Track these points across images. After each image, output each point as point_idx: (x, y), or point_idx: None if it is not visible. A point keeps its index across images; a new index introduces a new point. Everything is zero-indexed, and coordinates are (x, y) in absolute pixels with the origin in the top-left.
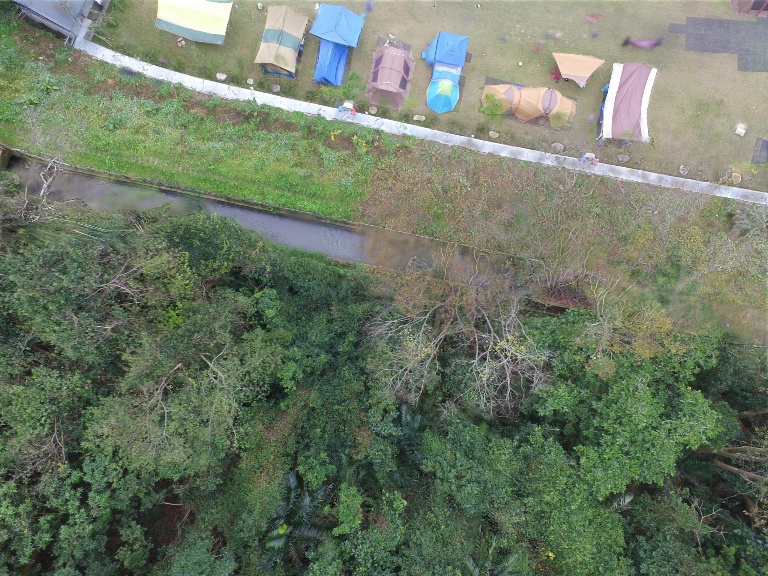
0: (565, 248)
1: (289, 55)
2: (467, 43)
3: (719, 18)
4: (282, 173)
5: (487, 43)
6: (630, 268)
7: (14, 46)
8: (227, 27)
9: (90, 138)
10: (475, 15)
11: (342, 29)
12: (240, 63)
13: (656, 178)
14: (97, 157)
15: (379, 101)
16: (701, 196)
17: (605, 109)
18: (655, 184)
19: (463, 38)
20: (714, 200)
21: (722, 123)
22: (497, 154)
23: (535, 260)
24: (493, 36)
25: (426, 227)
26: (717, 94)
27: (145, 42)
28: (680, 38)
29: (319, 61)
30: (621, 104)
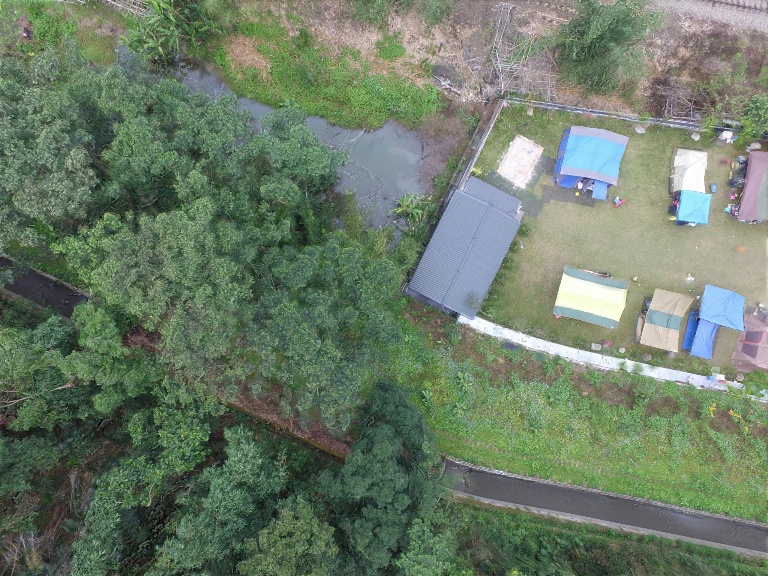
0: None
1: (676, 337)
2: None
3: None
4: (696, 475)
5: None
6: None
7: (415, 331)
8: (621, 314)
9: (518, 444)
10: None
11: (729, 312)
12: (613, 333)
13: None
14: (523, 461)
15: (746, 369)
16: None
17: None
18: None
19: None
20: None
21: None
22: None
23: None
24: None
25: None
26: None
27: (523, 314)
28: None
29: (697, 336)
30: None
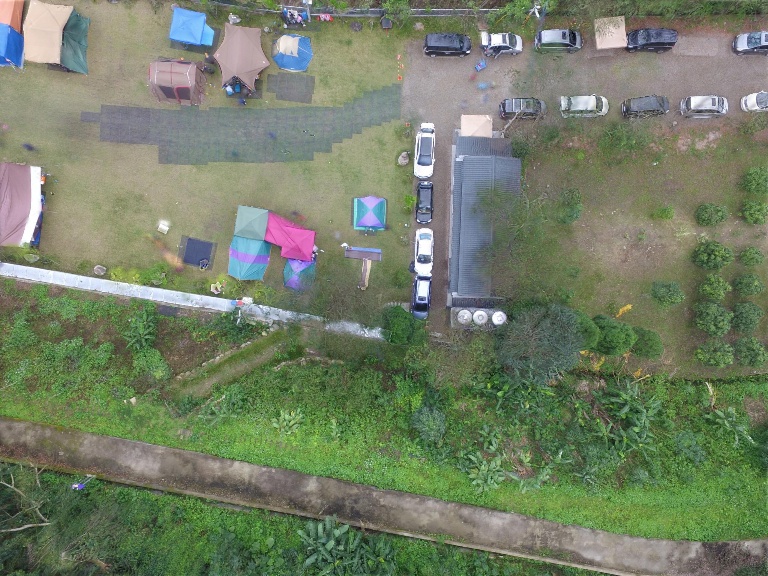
0: None
1: None
2: None
3: (137, 106)
4: None
5: None
6: None
7: None
8: None
9: None
10: None
11: None
12: None
13: (69, 279)
14: None
15: None
16: (118, 298)
17: None
18: (68, 285)
19: None
20: (131, 303)
21: (143, 220)
22: None
23: None
24: None
25: None
26: (136, 189)
27: None
28: (94, 128)
29: None
30: (3, 204)
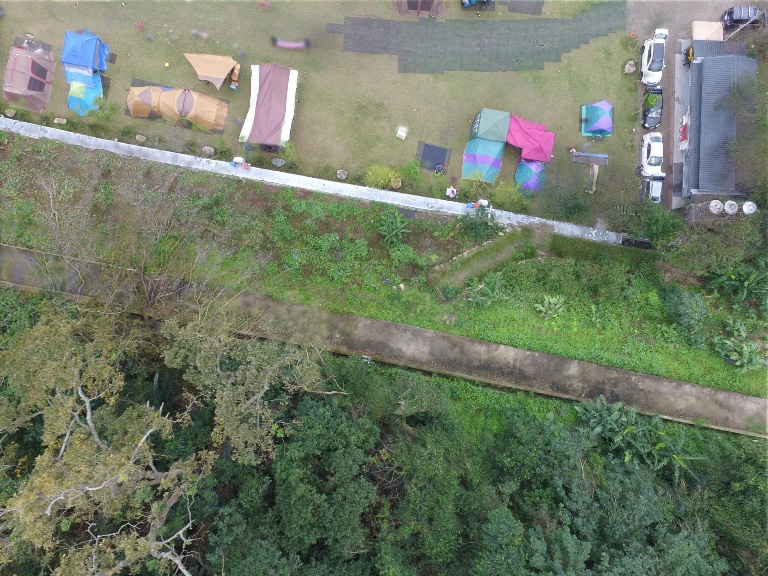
0: (170, 256)
1: None
2: (95, 43)
3: (378, 18)
4: None
5: (133, 43)
6: (239, 277)
7: None
8: None
9: None
10: (119, 14)
11: None
12: None
13: (313, 183)
14: None
15: (17, 103)
16: (359, 201)
17: (248, 112)
18: (312, 189)
19: (88, 38)
20: (372, 205)
21: (382, 126)
22: (144, 158)
23: (129, 269)
24: (139, 36)
25: (19, 235)
26: (376, 96)
27: None
28: (337, 38)
29: None
30: (261, 107)
